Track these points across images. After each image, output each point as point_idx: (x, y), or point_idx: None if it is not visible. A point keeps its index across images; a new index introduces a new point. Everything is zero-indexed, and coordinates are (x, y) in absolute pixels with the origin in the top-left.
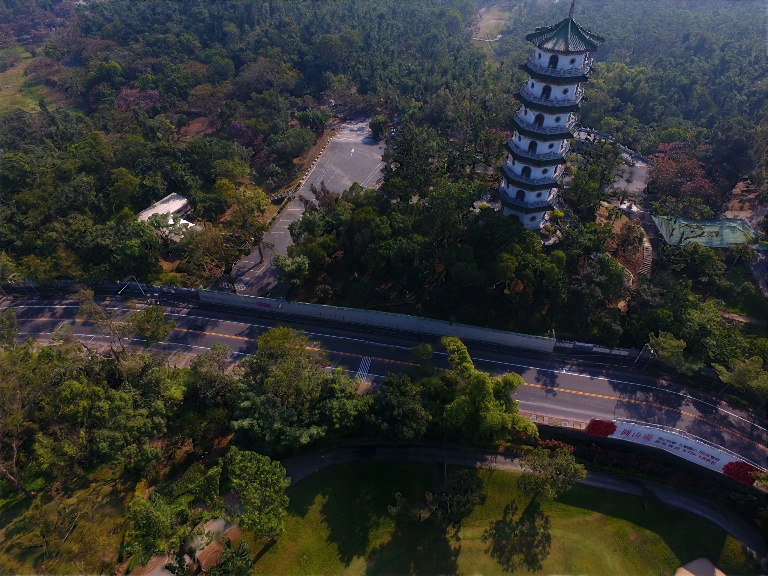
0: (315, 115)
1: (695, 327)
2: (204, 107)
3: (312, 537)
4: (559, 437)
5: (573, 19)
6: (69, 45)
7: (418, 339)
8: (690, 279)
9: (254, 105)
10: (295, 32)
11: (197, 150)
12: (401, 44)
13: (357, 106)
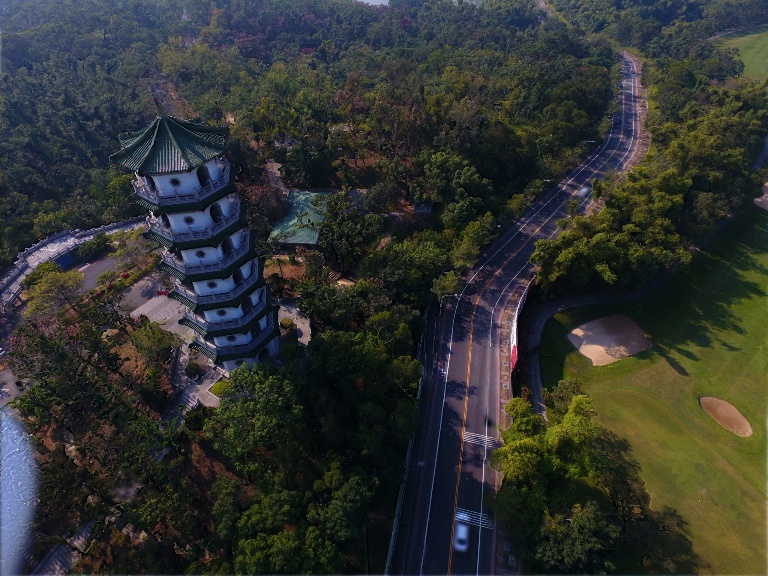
0: None
1: (435, 259)
2: None
3: None
4: (515, 396)
5: None
6: None
7: (409, 529)
8: None
9: None
10: None
11: None
12: None
13: None
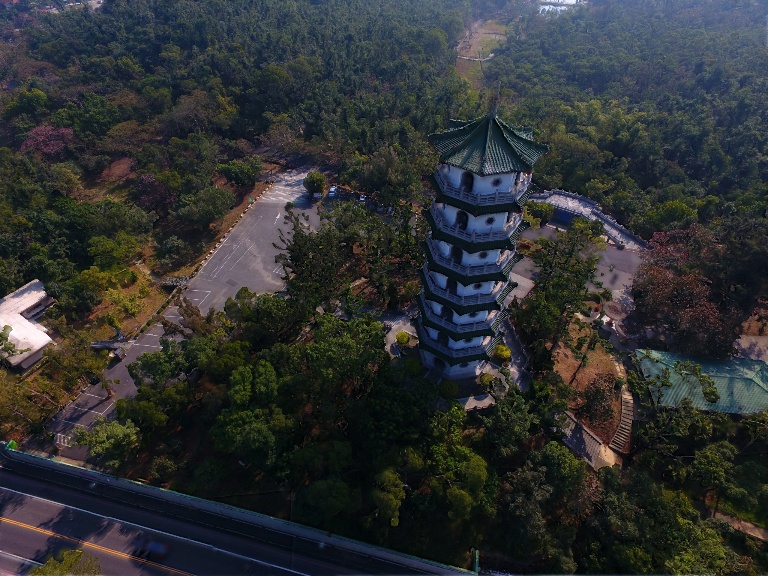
0: (239, 169)
1: None
2: (122, 150)
3: None
4: None
5: (496, 118)
6: (12, 63)
7: (287, 548)
8: (684, 464)
9: (176, 151)
10: (247, 56)
11: (77, 220)
12: (362, 75)
13: (305, 148)
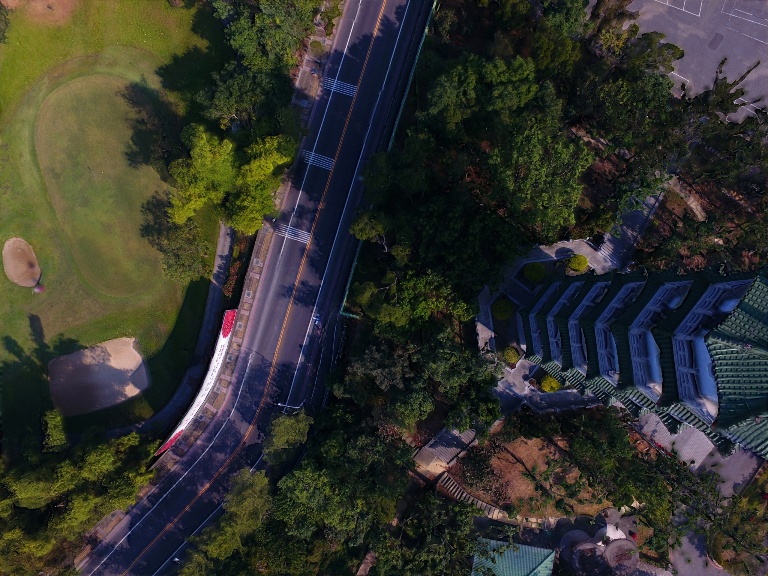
0: None
1: None
2: None
3: (176, 39)
4: None
5: None
6: None
7: None
8: None
9: None
10: None
11: None
12: None
13: None
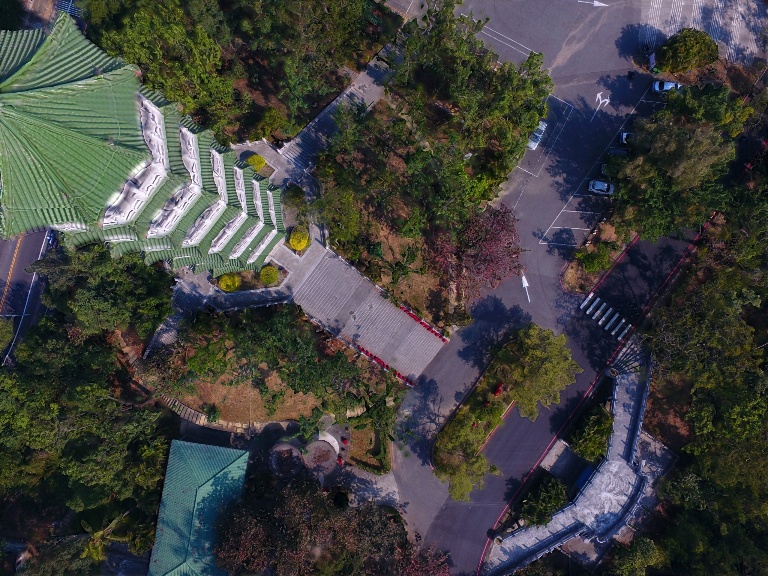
0: None
1: None
2: None
3: None
4: None
5: None
6: None
7: None
8: None
9: None
10: None
11: None
12: None
13: None
